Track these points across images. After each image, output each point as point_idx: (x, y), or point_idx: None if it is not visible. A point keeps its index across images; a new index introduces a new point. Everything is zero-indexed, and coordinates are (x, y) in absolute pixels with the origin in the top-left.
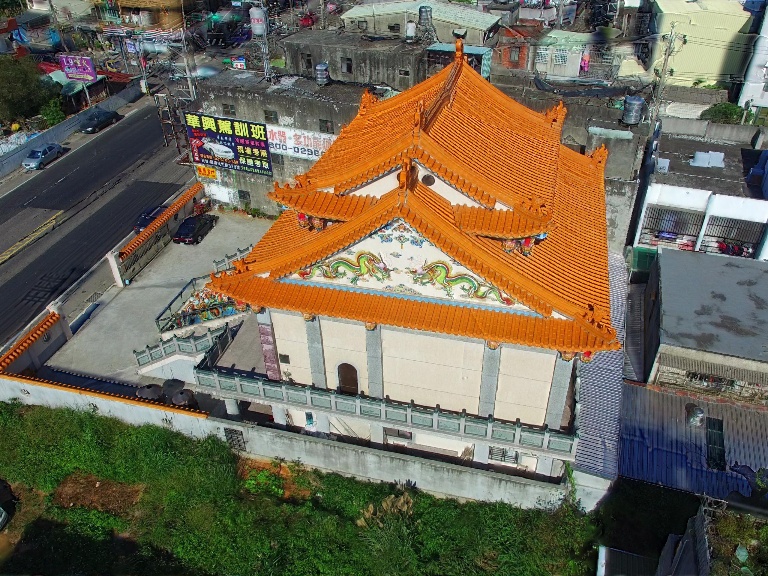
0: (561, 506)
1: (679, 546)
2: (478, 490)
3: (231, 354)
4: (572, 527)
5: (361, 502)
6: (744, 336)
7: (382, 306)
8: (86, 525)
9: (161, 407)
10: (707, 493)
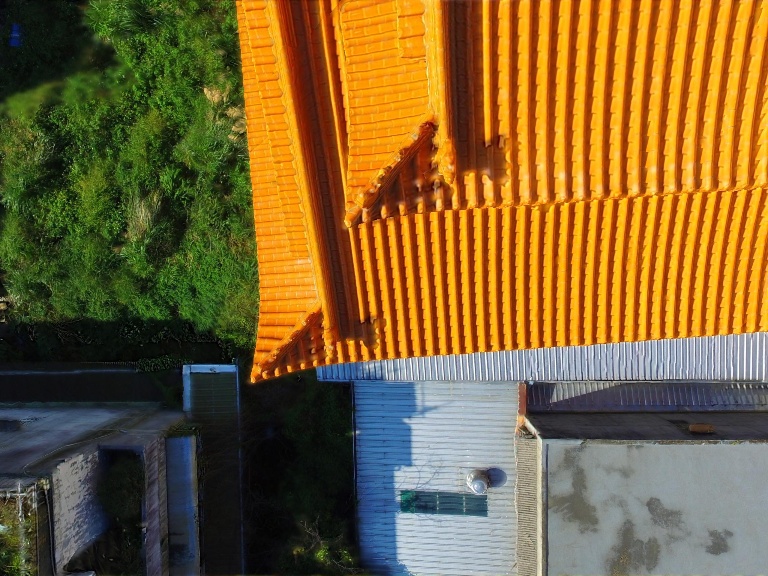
0: None
1: (69, 456)
2: None
3: None
4: (253, 332)
5: None
6: (607, 572)
7: None
8: None
9: None
10: (361, 486)
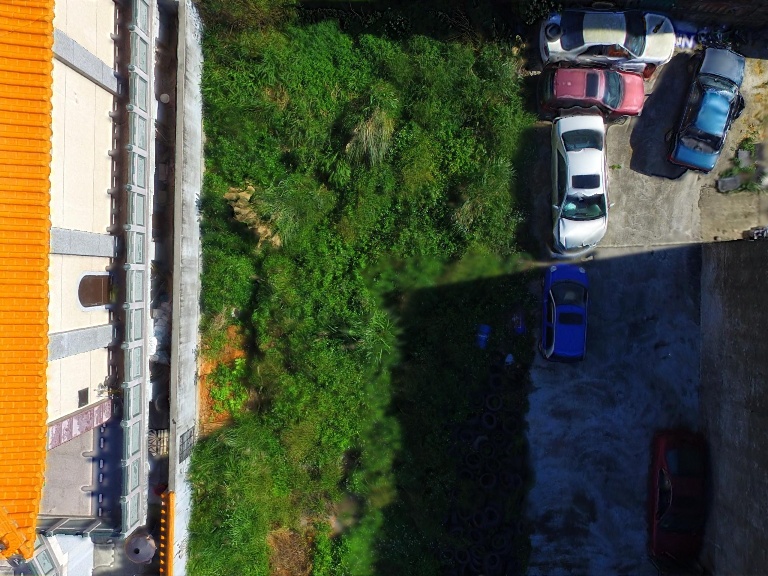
0: (198, 10)
1: None
2: (195, 112)
3: (62, 504)
4: None
5: (234, 258)
6: None
7: (8, 209)
8: (334, 572)
9: (170, 567)
10: None
